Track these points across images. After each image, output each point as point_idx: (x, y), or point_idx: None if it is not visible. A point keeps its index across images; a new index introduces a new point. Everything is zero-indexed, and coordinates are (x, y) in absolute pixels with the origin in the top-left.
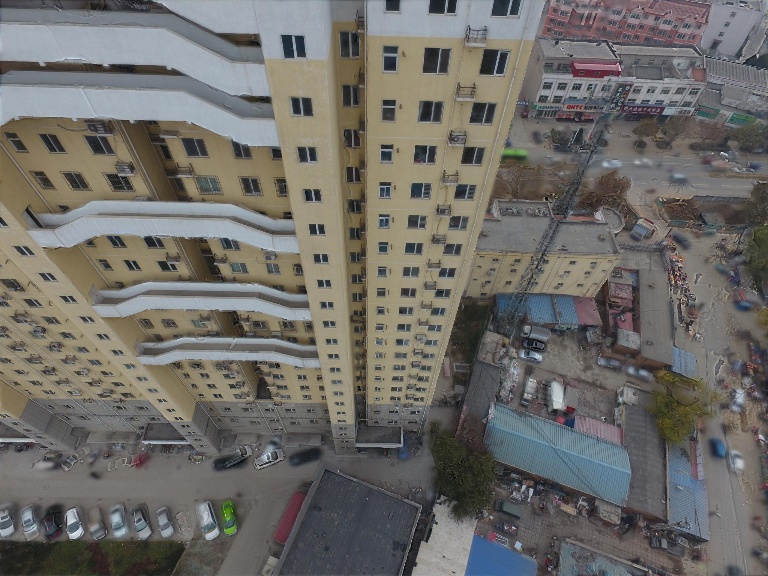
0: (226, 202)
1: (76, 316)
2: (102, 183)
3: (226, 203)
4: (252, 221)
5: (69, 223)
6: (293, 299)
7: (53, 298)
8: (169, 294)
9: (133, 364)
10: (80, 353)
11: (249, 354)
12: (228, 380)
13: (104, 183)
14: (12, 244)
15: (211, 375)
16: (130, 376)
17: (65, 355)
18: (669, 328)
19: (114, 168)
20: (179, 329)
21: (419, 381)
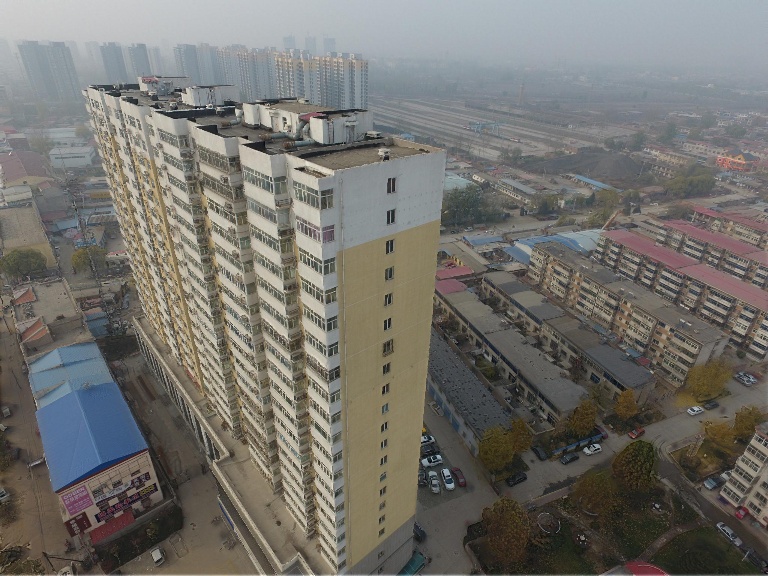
0: None
1: None
2: None
3: None
4: None
5: None
6: None
7: None
8: None
9: None
10: None
11: None
12: None
13: None
14: None
15: None
16: None
17: None
18: (95, 288)
19: None
20: None
21: None
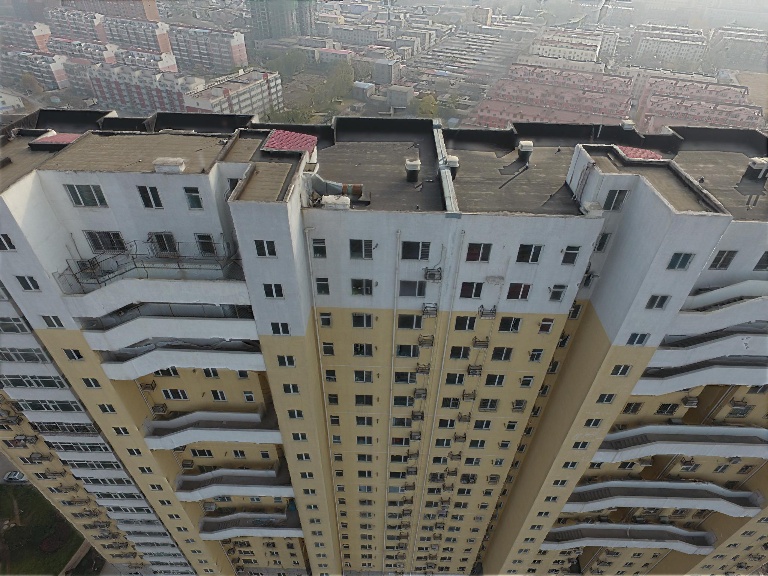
0: (743, 423)
1: (538, 511)
2: (652, 409)
3: (743, 424)
4: (767, 440)
5: (640, 447)
6: (729, 495)
7: (539, 498)
8: (641, 494)
9: (529, 549)
10: (449, 532)
11: (655, 543)
12: (561, 557)
13: (654, 409)
14: (568, 460)
15: (550, 552)
16: (510, 559)
17: (432, 533)
18: None
19: (675, 400)
20: (575, 514)
21: (750, 560)
